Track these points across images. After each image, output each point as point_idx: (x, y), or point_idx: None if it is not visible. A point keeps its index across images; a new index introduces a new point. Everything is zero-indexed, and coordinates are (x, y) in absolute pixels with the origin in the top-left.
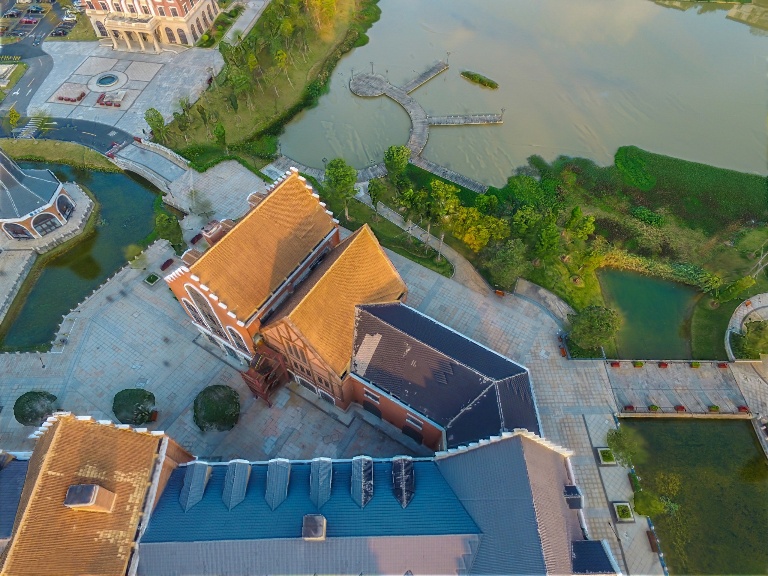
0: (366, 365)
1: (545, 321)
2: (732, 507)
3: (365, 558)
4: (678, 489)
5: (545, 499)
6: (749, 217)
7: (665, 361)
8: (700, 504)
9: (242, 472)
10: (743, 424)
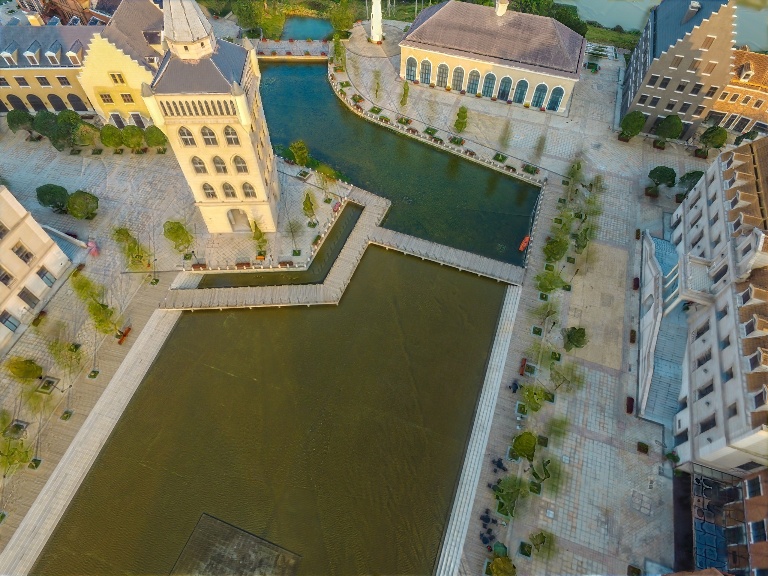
0: (96, 3)
1: (236, 27)
2: (297, 87)
3: (58, 34)
4: (273, 82)
5: (138, 8)
6: (404, 1)
7: (294, 40)
8: (281, 86)
9: (16, 21)
10: (325, 63)
